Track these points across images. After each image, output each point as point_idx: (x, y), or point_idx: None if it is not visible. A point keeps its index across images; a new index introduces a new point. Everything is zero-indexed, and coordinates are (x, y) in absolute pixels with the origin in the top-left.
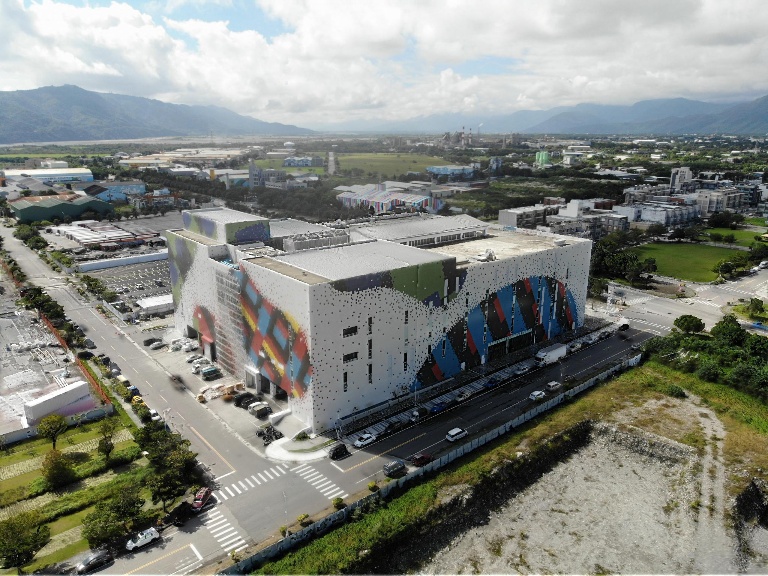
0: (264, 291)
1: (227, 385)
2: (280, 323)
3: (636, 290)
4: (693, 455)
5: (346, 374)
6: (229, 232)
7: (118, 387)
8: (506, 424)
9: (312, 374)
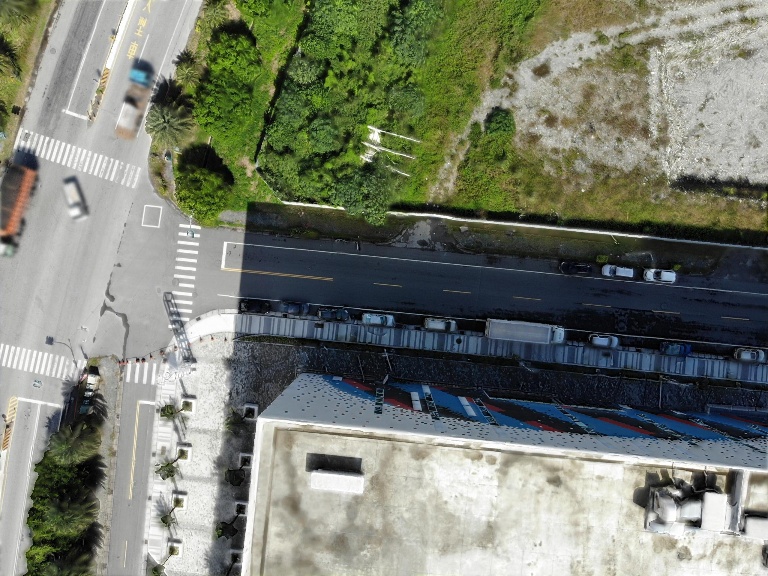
0: None
1: None
2: None
3: None
4: None
5: None
6: None
7: None
8: None
9: None
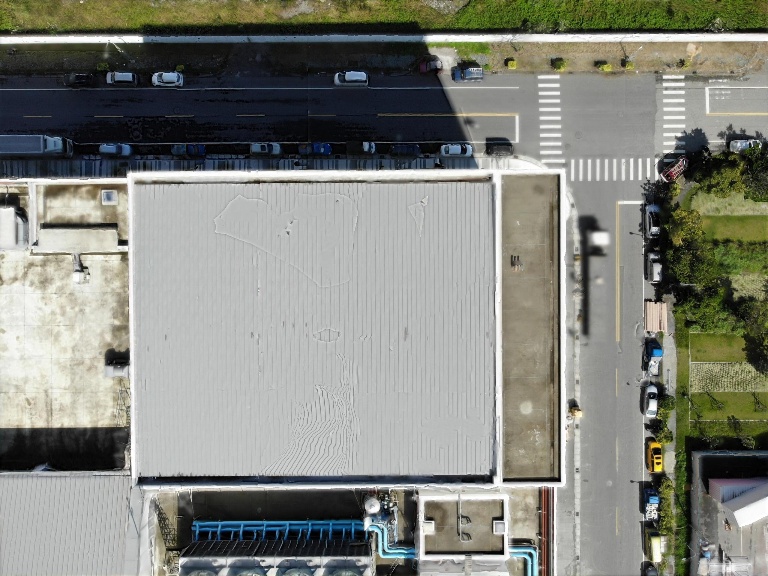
0: None
1: None
2: None
3: None
4: None
5: None
6: None
7: (672, 519)
8: (292, 37)
9: None
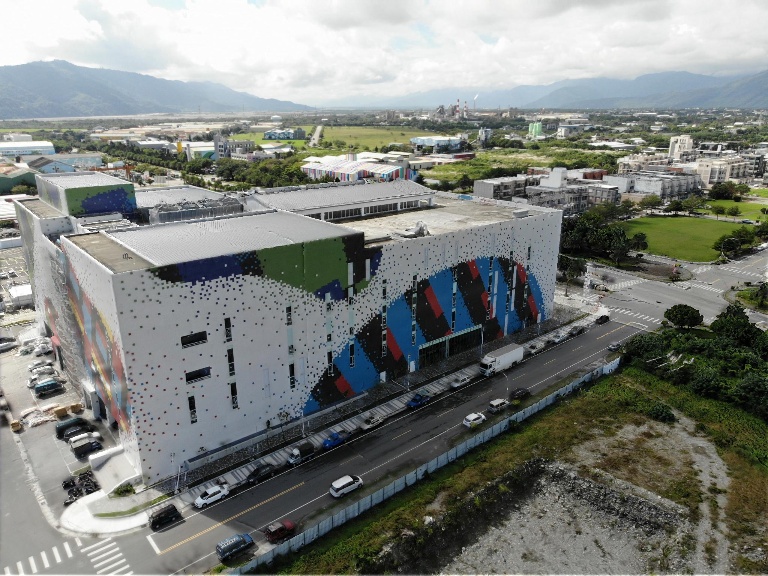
0: (81, 281)
1: (62, 405)
2: (98, 327)
3: (622, 272)
4: (682, 520)
5: (193, 399)
6: (72, 200)
7: None
8: (417, 470)
9: (132, 402)
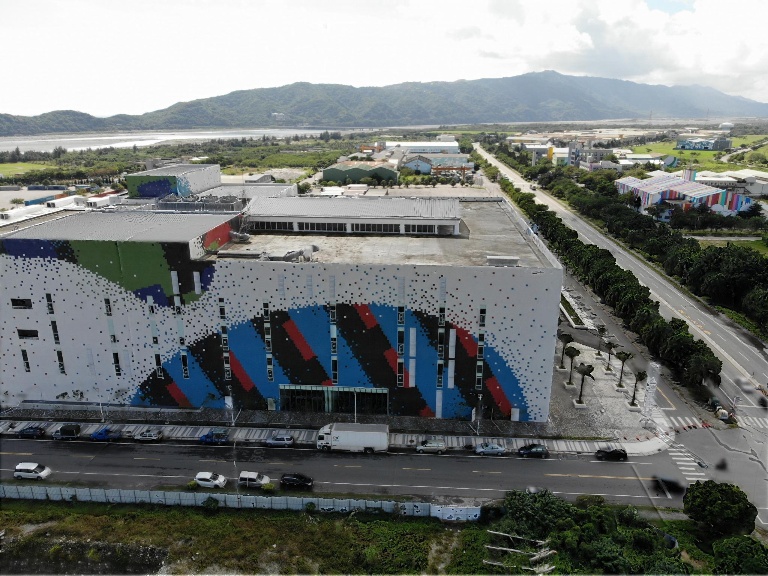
0: None
1: None
2: None
3: None
4: None
5: (26, 352)
6: (131, 185)
7: None
8: (62, 489)
9: None
